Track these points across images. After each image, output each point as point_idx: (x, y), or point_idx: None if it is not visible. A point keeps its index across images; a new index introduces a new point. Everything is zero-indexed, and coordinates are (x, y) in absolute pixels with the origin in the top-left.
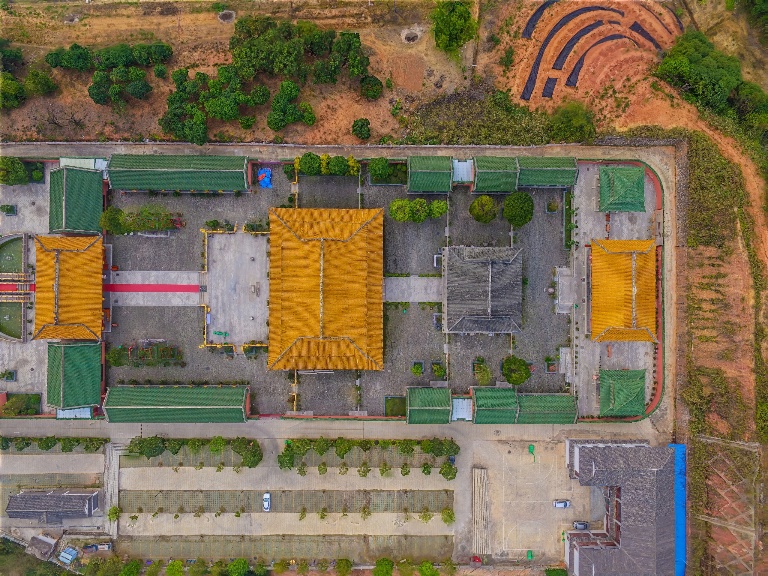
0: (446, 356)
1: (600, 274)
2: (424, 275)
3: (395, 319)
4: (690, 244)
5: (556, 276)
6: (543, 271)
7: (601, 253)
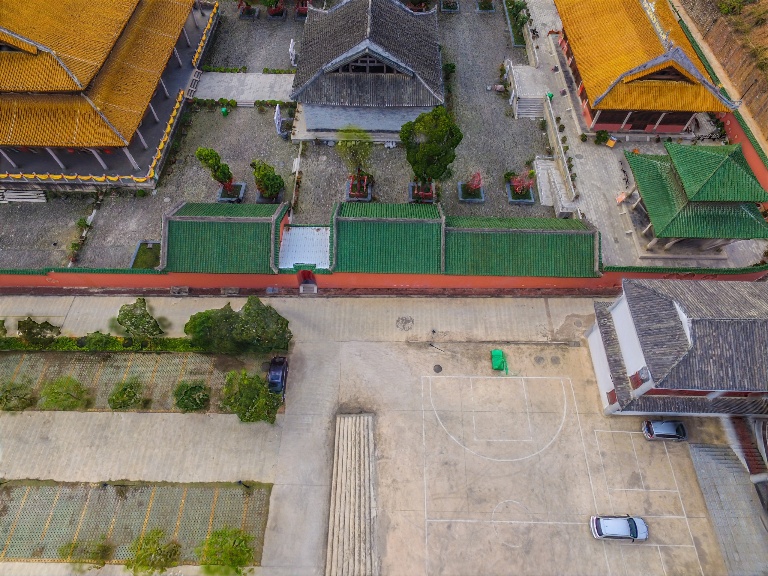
0: (295, 177)
1: (579, 24)
2: (271, 69)
3: (205, 125)
4: (726, 8)
5: (506, 69)
6: (482, 68)
7: (573, 3)
